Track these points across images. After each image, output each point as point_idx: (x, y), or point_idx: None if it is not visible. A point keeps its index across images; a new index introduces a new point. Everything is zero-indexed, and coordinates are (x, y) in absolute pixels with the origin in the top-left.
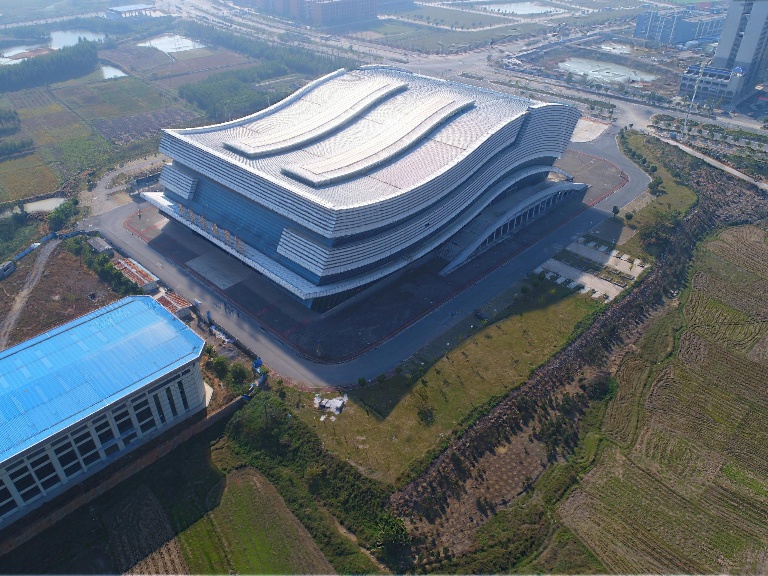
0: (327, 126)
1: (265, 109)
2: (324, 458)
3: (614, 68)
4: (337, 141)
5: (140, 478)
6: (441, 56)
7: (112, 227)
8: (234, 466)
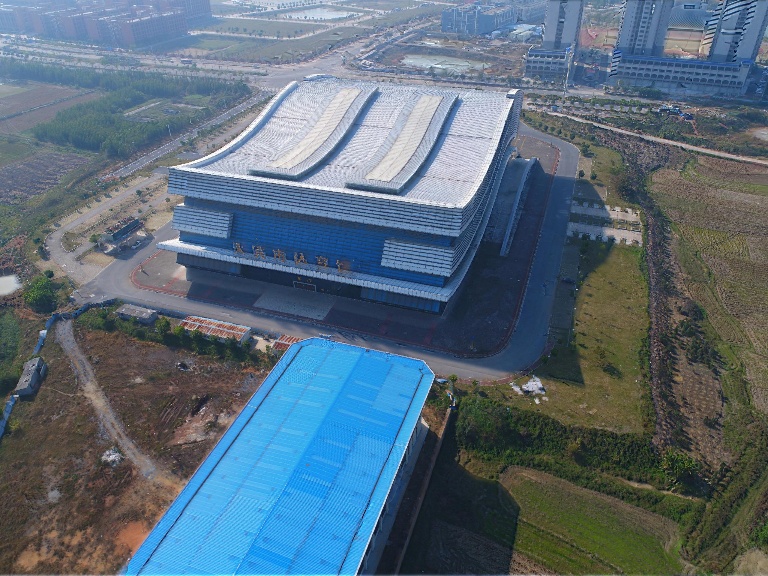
0: (335, 138)
1: (244, 132)
2: (573, 432)
3: (448, 60)
4: (355, 150)
5: (426, 516)
6: (293, 65)
7: (123, 291)
8: (497, 471)
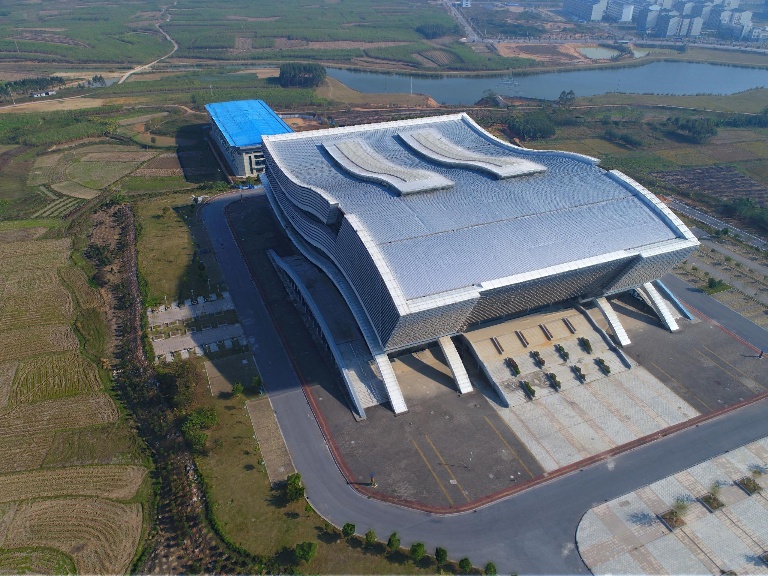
0: (441, 157)
1: None
2: None
3: None
4: (414, 164)
5: None
6: None
7: None
8: None
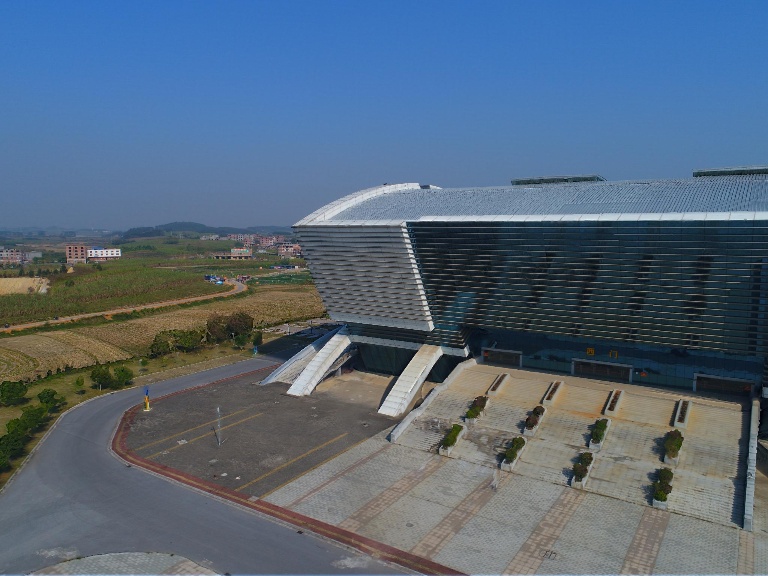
0: None
1: None
2: None
3: None
4: None
5: None
6: None
7: None
8: None
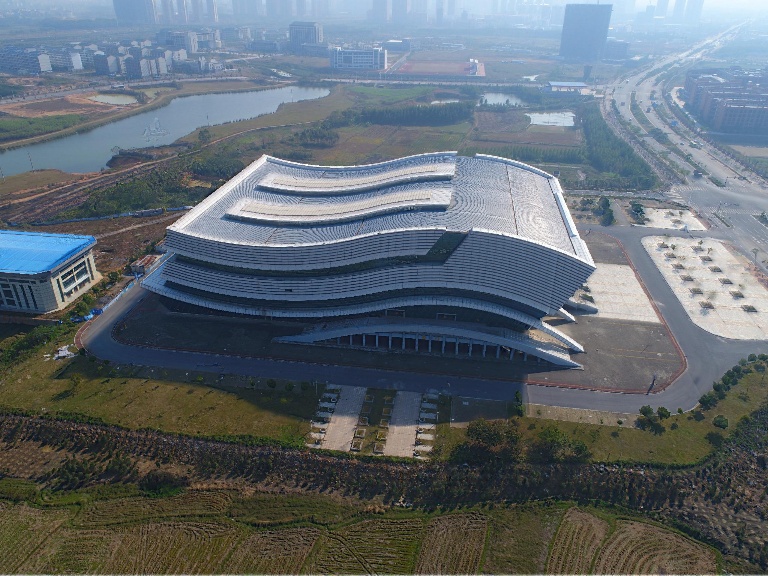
0: (345, 188)
1: None
2: None
3: None
4: (332, 201)
5: None
6: None
7: None
8: None
